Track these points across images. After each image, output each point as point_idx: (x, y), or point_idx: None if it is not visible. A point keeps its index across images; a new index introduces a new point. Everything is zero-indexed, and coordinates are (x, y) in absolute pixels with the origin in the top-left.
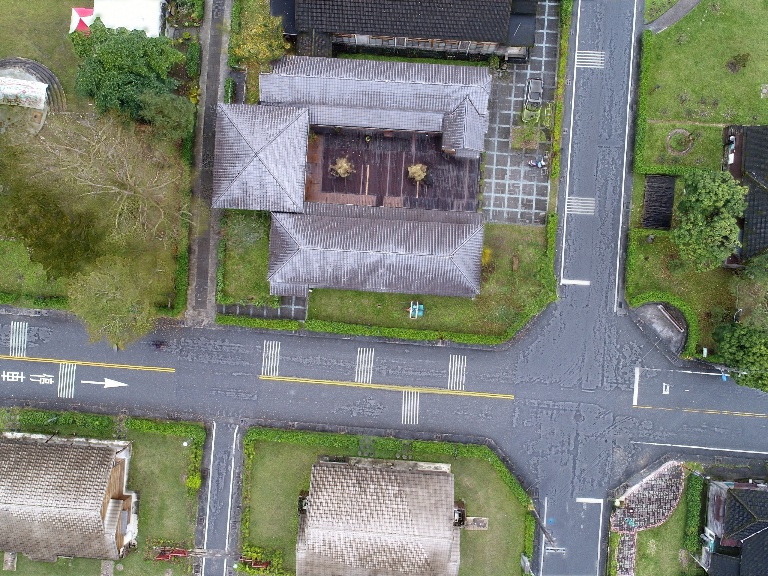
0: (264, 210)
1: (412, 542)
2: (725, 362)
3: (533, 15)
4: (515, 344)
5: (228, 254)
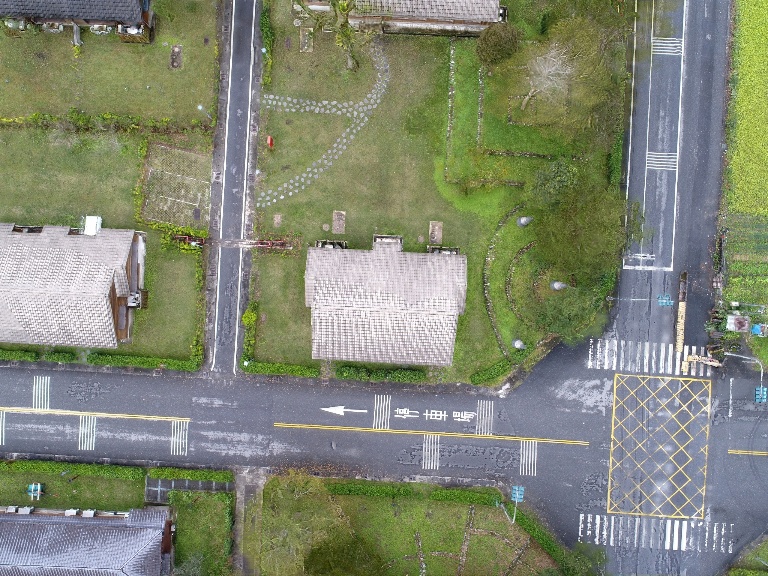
0: None
1: (4, 283)
2: None
3: None
4: None
5: None
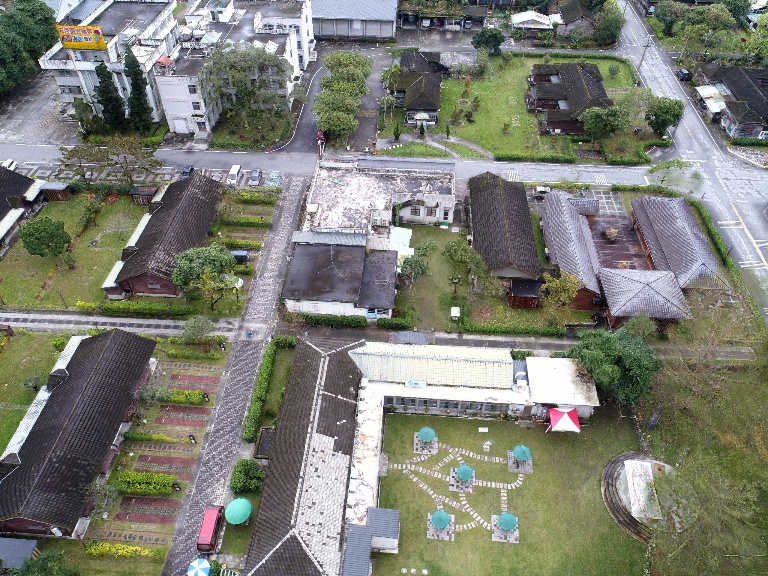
0: None
1: None
2: (673, 122)
3: None
4: None
5: None
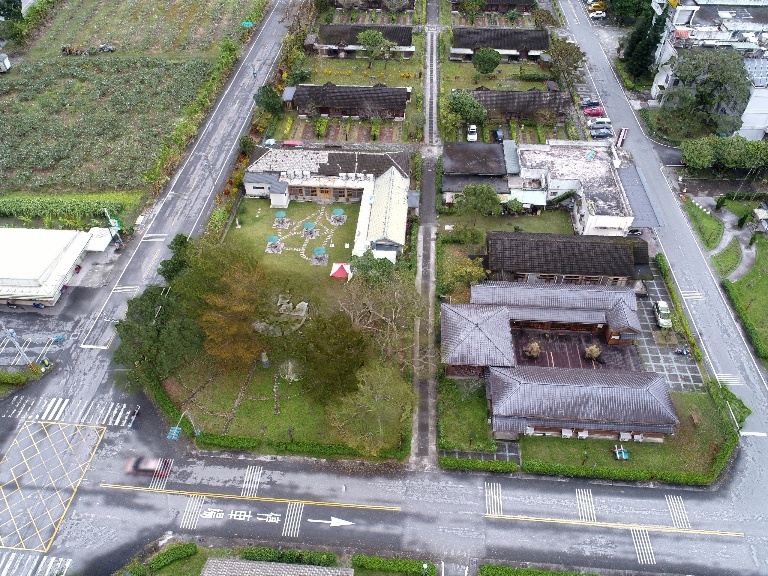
0: (484, 365)
1: None
2: None
3: (647, 265)
4: (723, 485)
5: (445, 413)
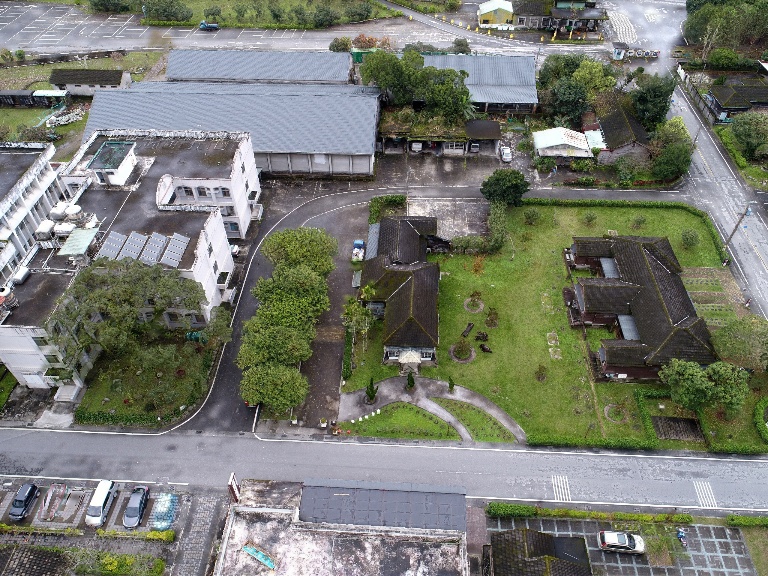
0: None
1: None
2: None
3: None
4: None
5: None
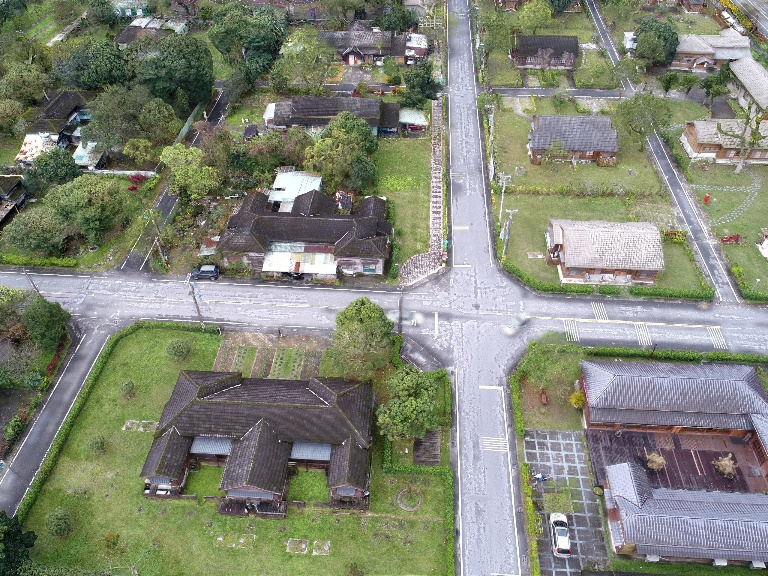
0: None
1: None
2: None
3: None
4: None
5: None
